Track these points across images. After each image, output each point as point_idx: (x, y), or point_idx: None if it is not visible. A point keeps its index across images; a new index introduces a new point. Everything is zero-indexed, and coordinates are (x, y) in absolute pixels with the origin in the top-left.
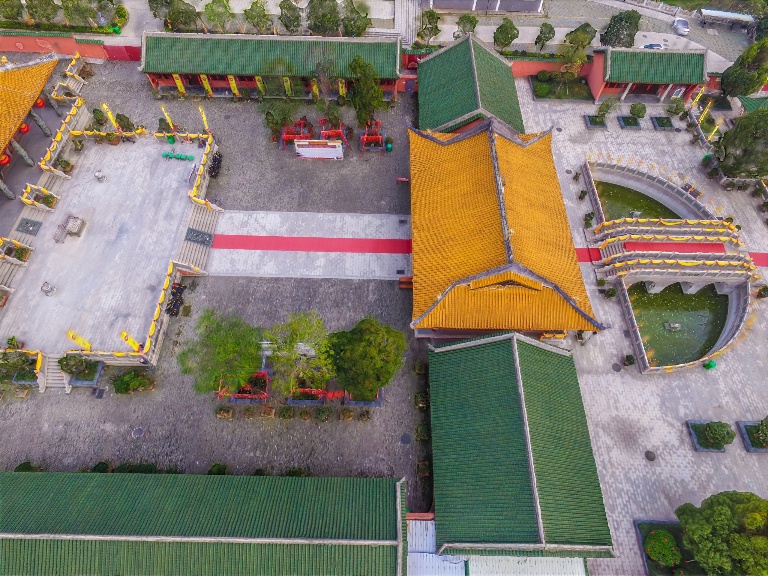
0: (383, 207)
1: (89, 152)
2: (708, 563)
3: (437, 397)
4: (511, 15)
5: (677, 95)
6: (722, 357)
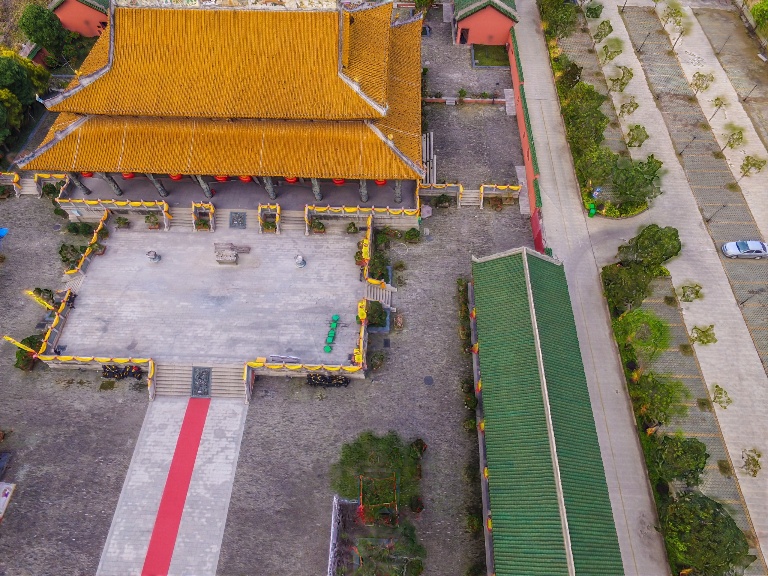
0: None
1: (347, 241)
2: None
3: None
4: None
5: None
6: None
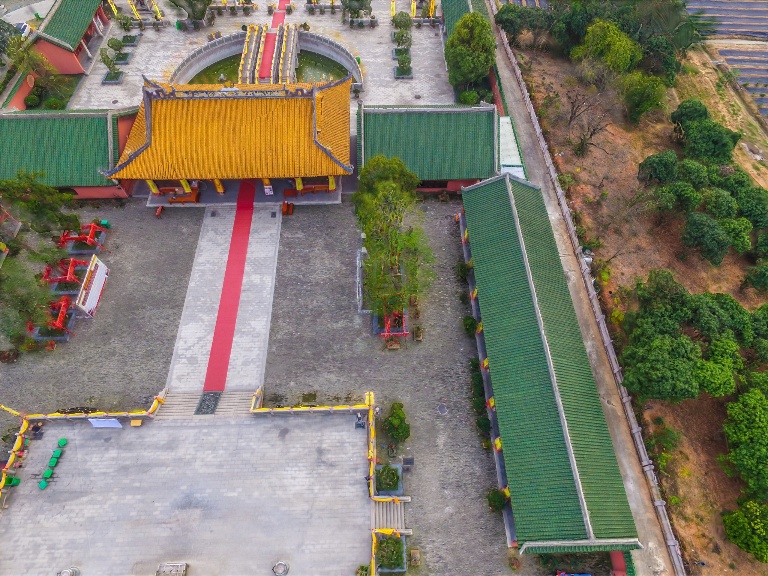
0: (191, 230)
1: None
2: None
3: None
4: None
5: (100, 24)
6: None
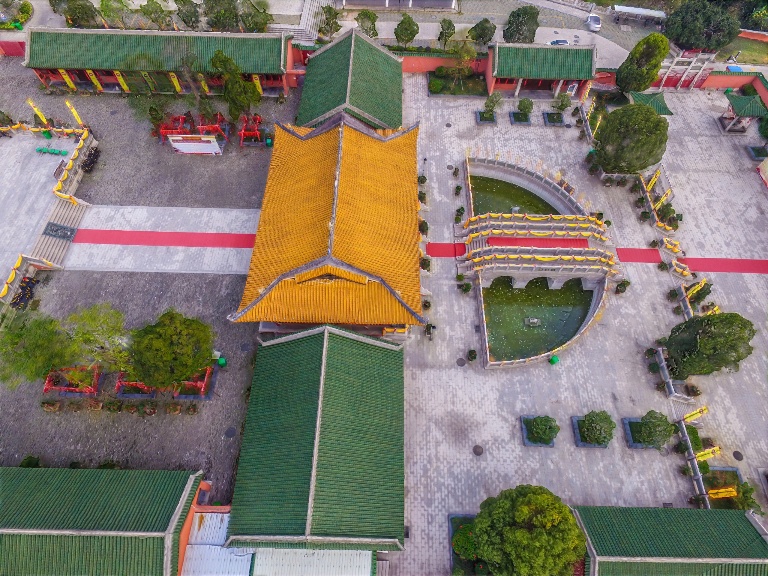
0: (253, 202)
1: None
2: (484, 556)
3: (256, 391)
4: (424, 11)
5: (571, 91)
6: (569, 352)
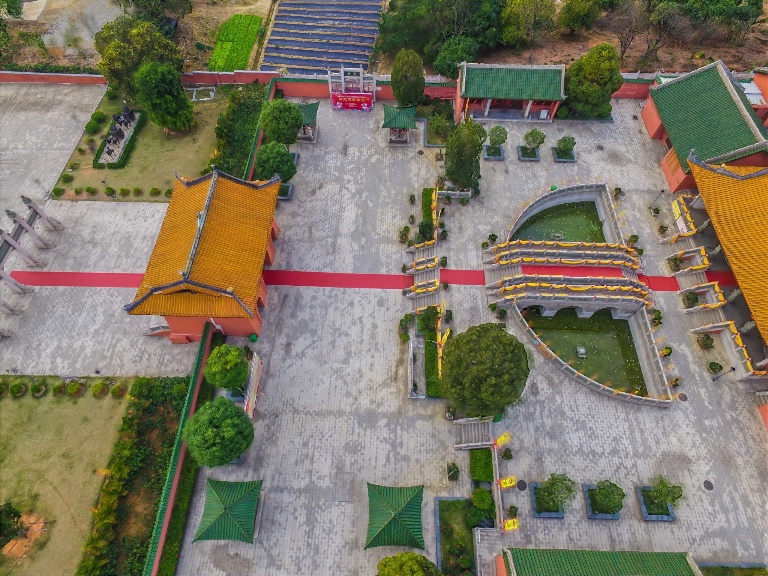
0: None
1: None
2: None
3: None
4: None
5: None
6: None
